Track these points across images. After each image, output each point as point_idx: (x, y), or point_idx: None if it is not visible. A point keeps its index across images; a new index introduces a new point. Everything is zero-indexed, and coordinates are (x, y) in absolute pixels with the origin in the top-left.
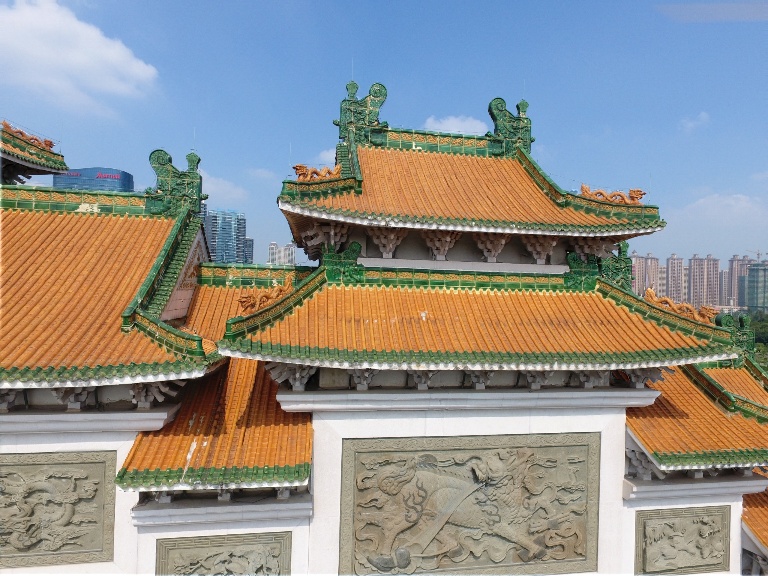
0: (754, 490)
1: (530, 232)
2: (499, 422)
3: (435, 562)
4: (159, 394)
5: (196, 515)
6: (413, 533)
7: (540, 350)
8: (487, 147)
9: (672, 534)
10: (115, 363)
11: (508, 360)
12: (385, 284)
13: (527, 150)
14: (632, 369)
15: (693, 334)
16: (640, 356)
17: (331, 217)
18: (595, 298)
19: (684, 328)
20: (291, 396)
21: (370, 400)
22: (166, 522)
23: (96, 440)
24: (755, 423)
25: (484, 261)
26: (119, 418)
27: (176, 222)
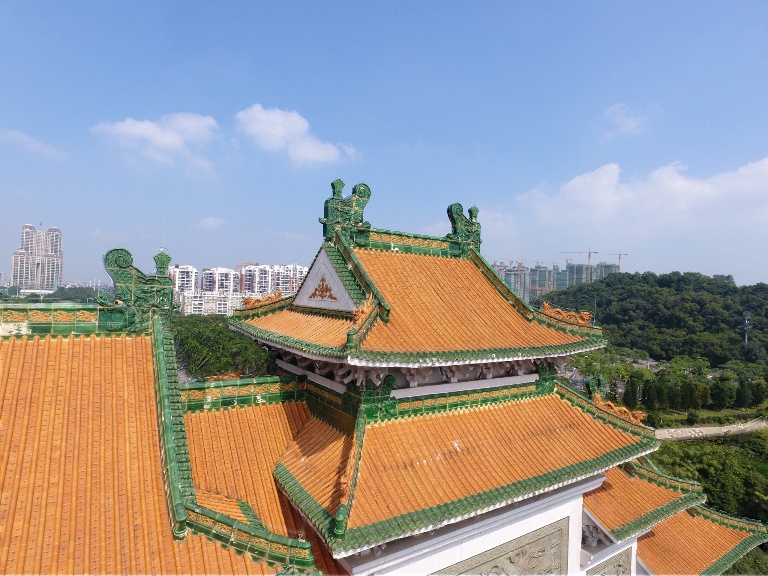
0: (646, 532)
1: (529, 358)
2: (510, 530)
3: None
4: None
5: None
6: None
7: (552, 468)
8: (449, 248)
9: None
10: None
11: (539, 486)
12: (414, 414)
13: (477, 251)
14: None
15: (629, 432)
16: (609, 459)
17: (389, 365)
18: (556, 400)
19: (623, 427)
20: (366, 565)
21: (429, 546)
22: None
23: None
24: (647, 483)
25: (484, 378)
26: None
27: (159, 349)
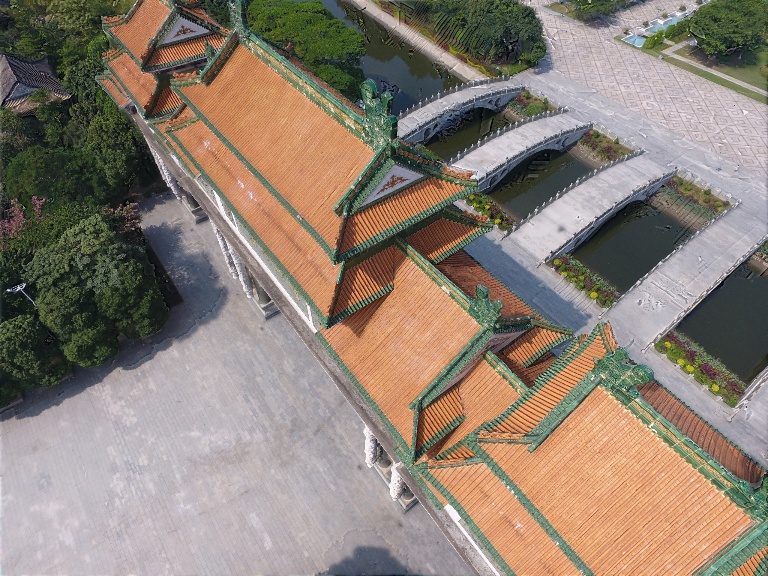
0: None
1: None
2: None
3: None
4: None
5: None
6: None
7: None
8: (730, 488)
9: None
10: (397, 427)
11: None
12: None
13: None
14: None
15: None
16: None
17: None
18: None
19: None
20: None
21: None
22: None
23: None
24: None
25: None
26: None
27: (469, 342)
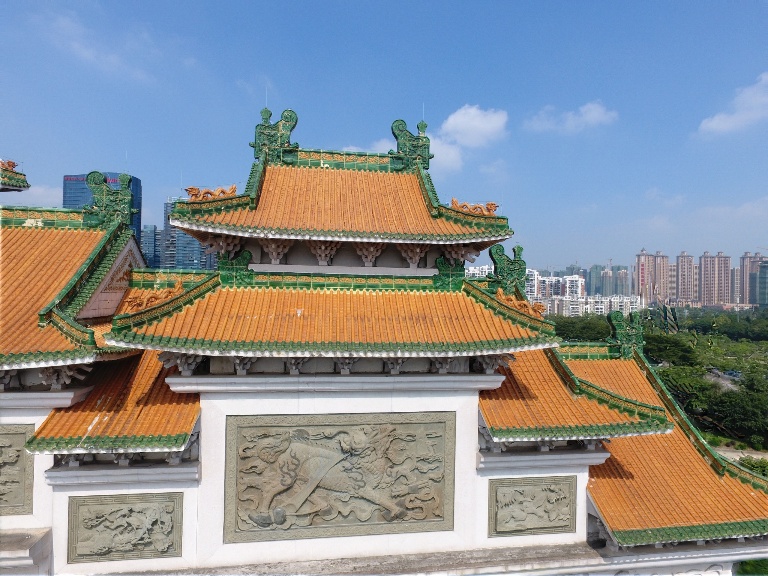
0: (595, 462)
1: (393, 241)
2: (364, 402)
3: (308, 520)
4: (67, 377)
5: (99, 476)
6: (289, 495)
7: (389, 341)
8: (389, 163)
9: (522, 499)
10: (26, 352)
11: (357, 349)
12: (272, 286)
13: (426, 165)
14: (483, 357)
15: (528, 327)
16: (475, 345)
17: (216, 231)
18: (460, 297)
19: (522, 322)
20: (178, 379)
21: (246, 383)
22: (74, 482)
23: (18, 415)
24: (595, 404)
25: (362, 266)
26: (34, 397)
27: (105, 234)
